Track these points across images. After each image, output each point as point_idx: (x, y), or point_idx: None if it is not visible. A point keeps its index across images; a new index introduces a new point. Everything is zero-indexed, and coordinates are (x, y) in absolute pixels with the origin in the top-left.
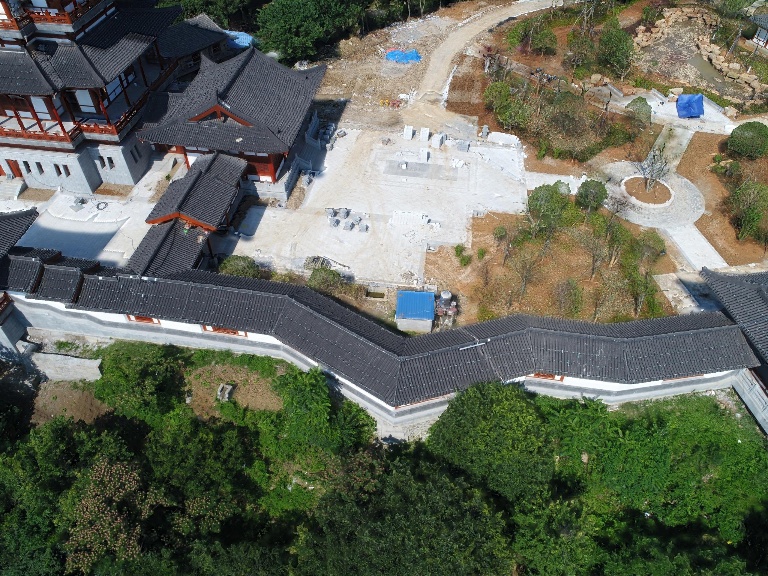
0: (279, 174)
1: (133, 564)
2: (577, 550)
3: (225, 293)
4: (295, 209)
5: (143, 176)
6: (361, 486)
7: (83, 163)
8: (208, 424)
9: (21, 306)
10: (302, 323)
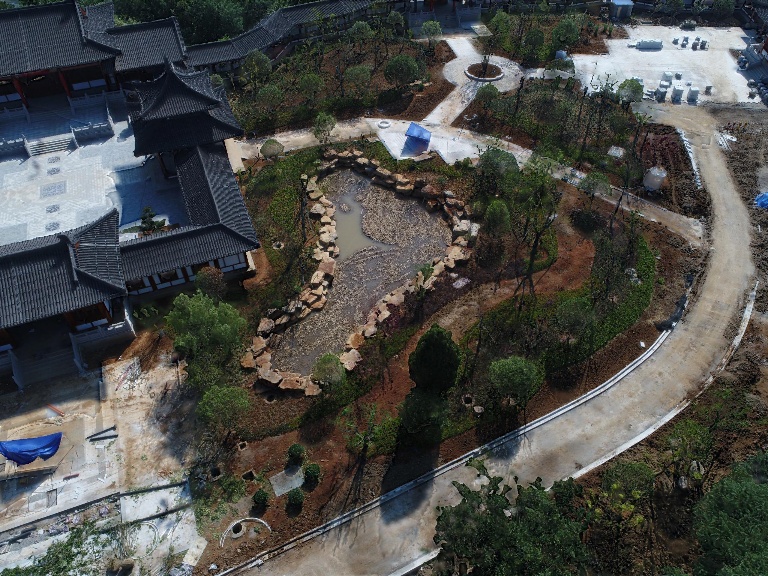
0: (764, 57)
1: None
2: None
3: None
4: None
5: None
6: None
7: None
8: None
9: None
10: None
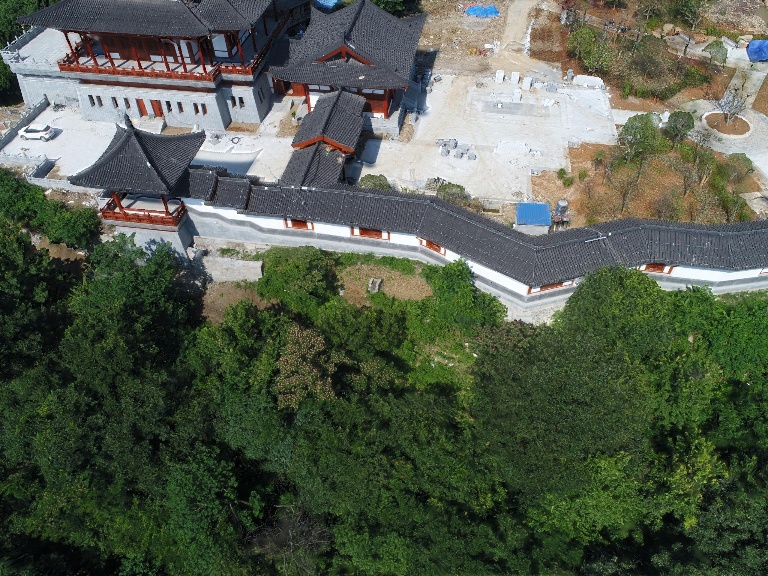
0: (389, 112)
1: (328, 406)
2: (704, 390)
3: (374, 200)
4: (408, 141)
5: (266, 116)
6: (515, 344)
7: (219, 102)
8: (361, 311)
9: (194, 215)
10: (443, 223)
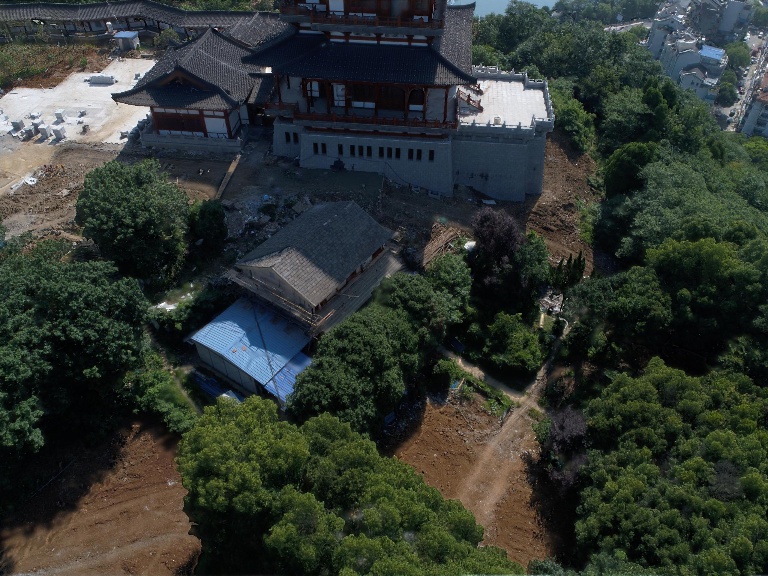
0: None
1: None
2: None
3: None
4: None
5: None
6: None
7: None
8: None
9: None
10: None
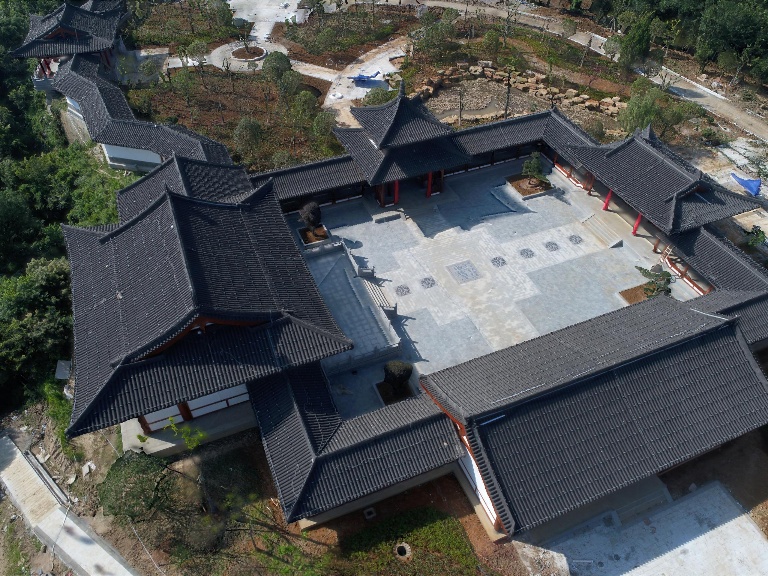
0: None
1: None
2: None
3: None
4: None
5: None
6: None
7: None
8: None
9: None
10: None
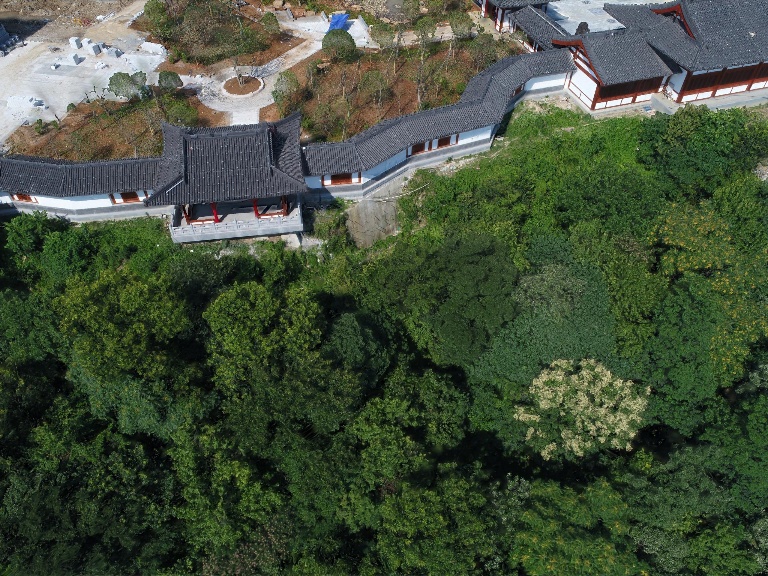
0: None
1: None
2: None
3: None
4: None
5: None
6: None
7: None
8: None
9: None
10: None
